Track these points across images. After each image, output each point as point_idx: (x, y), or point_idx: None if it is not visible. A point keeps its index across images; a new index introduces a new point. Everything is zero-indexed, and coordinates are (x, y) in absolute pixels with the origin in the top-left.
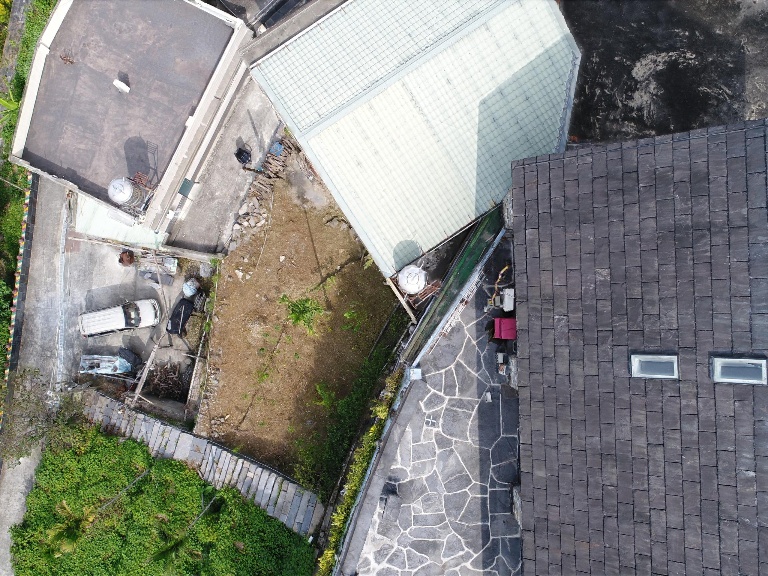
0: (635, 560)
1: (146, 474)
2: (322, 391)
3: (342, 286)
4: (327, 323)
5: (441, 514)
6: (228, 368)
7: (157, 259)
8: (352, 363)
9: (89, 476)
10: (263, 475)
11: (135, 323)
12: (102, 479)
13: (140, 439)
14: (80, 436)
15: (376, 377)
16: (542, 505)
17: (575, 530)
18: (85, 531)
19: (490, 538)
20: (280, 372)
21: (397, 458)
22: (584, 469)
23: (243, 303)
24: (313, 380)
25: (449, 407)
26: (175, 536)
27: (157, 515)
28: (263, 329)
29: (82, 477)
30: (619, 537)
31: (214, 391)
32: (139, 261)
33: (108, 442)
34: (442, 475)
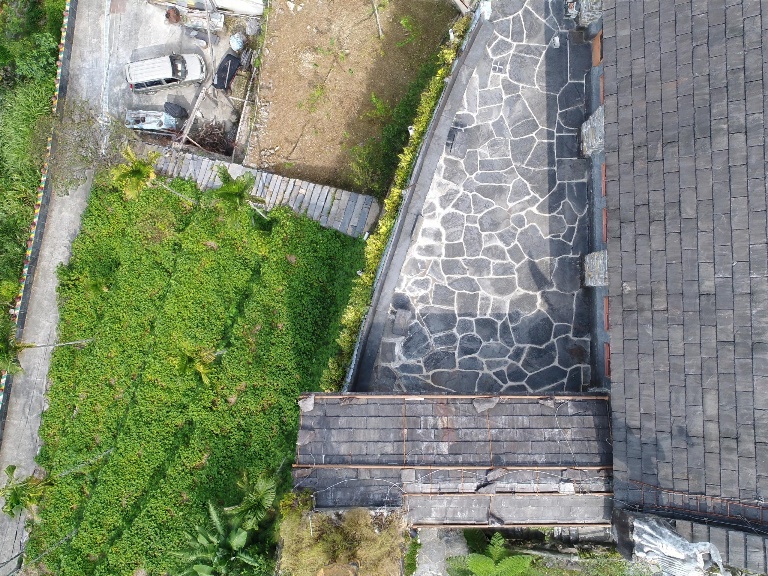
0: (727, 77)
1: (194, 210)
2: (377, 99)
3: (395, 12)
4: (379, 48)
5: (507, 159)
6: (278, 100)
7: (204, 14)
8: (405, 84)
9: (136, 214)
10: (316, 189)
11: (181, 75)
12: (149, 217)
13: (188, 177)
14: None
15: (433, 74)
16: (626, 63)
17: (662, 73)
18: (149, 176)
19: (556, 182)
20: (331, 100)
21: (464, 104)
22: (672, 9)
23: (294, 35)
24: (365, 104)
25: (516, 53)
26: (240, 177)
27: (206, 243)
28: (314, 58)
29: (128, 222)
30: (710, 61)
31: (264, 123)
32: (185, 20)
33: None
34: (509, 120)
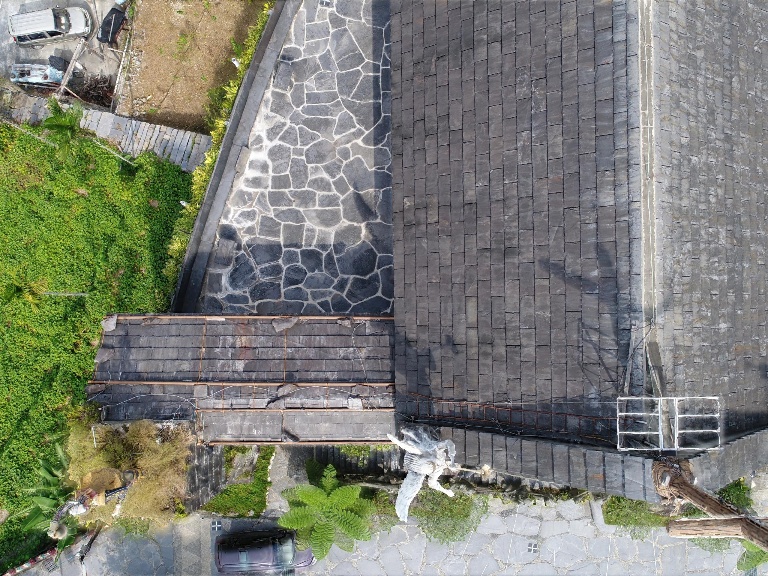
0: None
1: None
2: (236, 44)
3: None
4: None
5: (334, 92)
6: (151, 50)
7: None
8: None
9: (13, 163)
10: (178, 134)
11: (65, 29)
12: None
13: None
14: (7, 132)
15: None
16: None
17: None
18: None
19: (381, 115)
20: (201, 49)
21: (291, 37)
22: None
23: None
24: (232, 52)
25: None
26: (69, 110)
27: (77, 191)
28: (185, 7)
29: None
30: None
31: (136, 72)
32: None
33: (33, 130)
34: (335, 54)
